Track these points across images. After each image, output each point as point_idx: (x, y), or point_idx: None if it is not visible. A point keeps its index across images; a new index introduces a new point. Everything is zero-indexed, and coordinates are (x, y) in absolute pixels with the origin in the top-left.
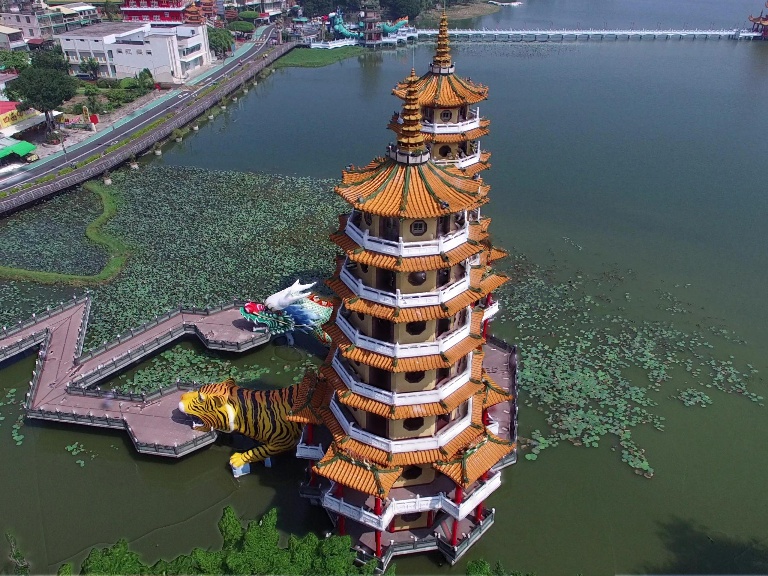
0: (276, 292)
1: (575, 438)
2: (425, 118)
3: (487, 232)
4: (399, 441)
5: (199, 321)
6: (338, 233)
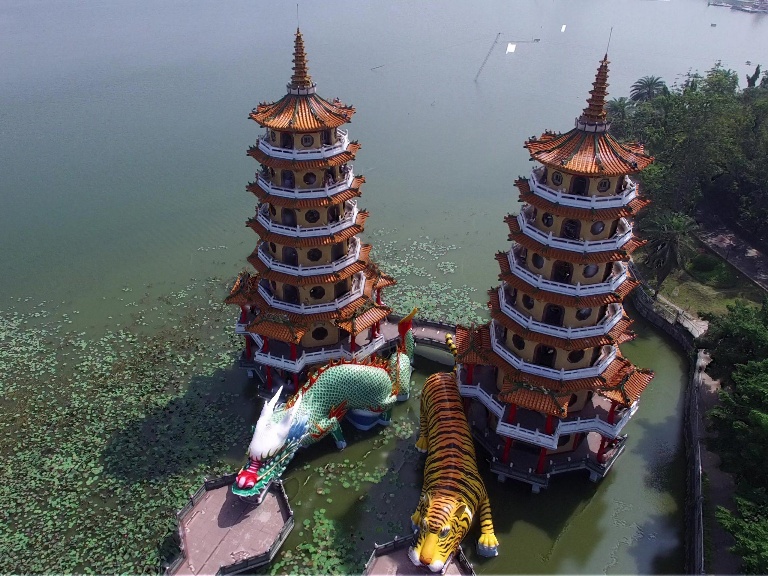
0: (142, 485)
1: None
2: (322, 143)
3: (145, 286)
4: (602, 351)
5: (196, 571)
6: (594, 213)
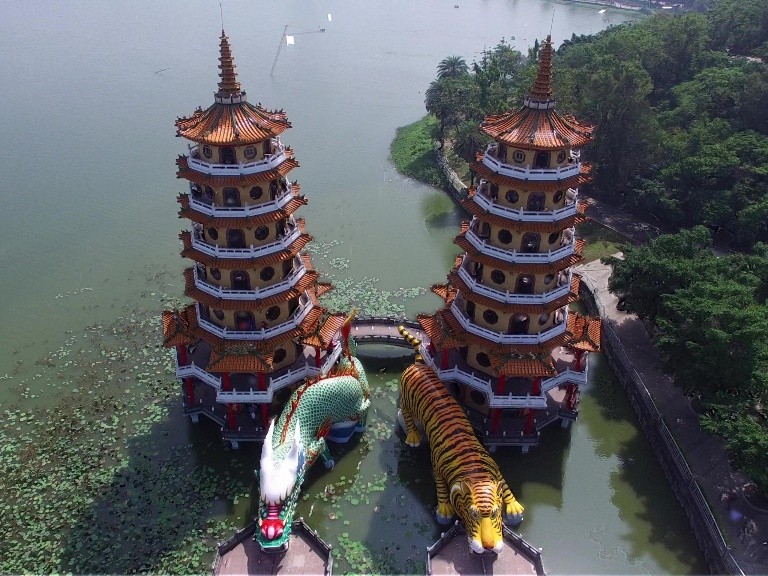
0: None
1: (398, 314)
2: None
3: (10, 353)
4: None
5: None
6: None
